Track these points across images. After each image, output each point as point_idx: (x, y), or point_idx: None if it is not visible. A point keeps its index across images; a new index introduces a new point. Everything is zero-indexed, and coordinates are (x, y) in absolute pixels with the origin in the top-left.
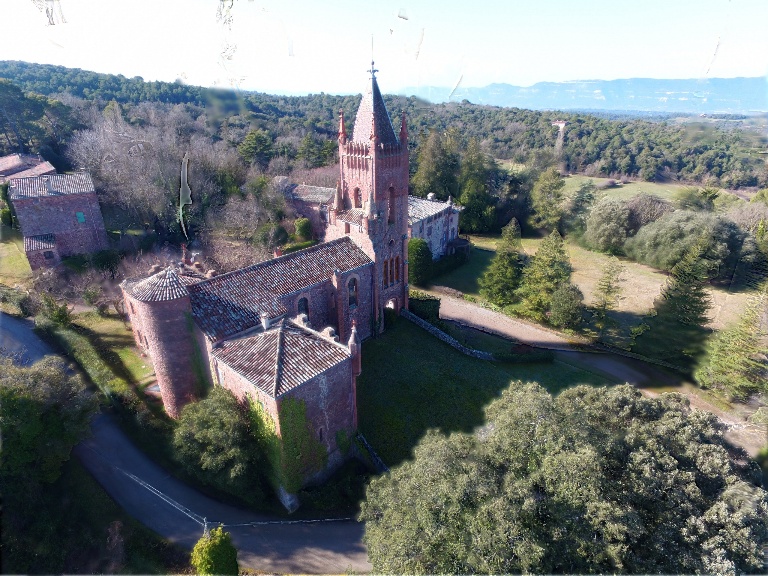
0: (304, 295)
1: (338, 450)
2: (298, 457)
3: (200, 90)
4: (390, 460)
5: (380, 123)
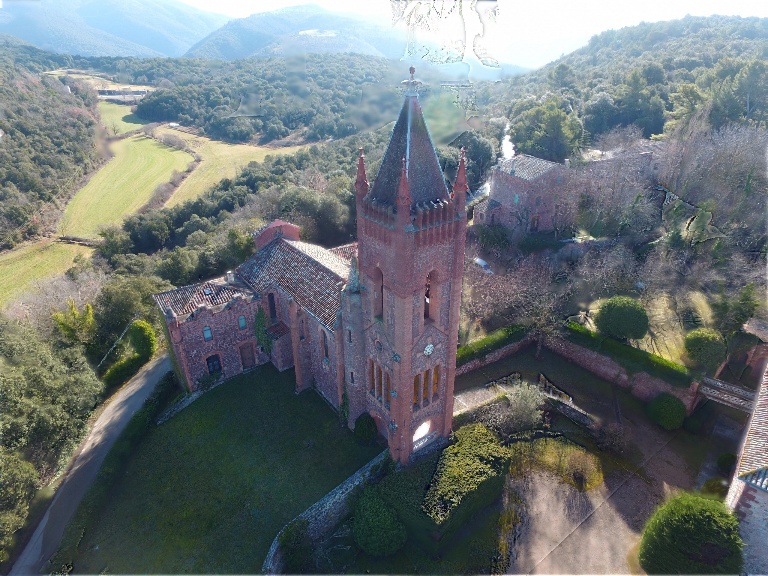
0: None
1: None
2: None
3: (351, 96)
4: (168, 425)
5: (391, 168)
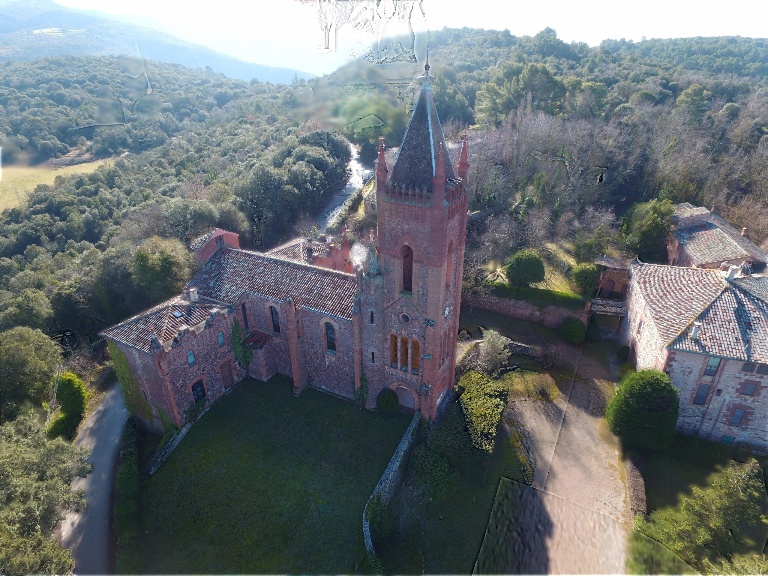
0: (274, 304)
1: None
2: (129, 392)
3: (297, 95)
4: (165, 470)
5: (412, 154)
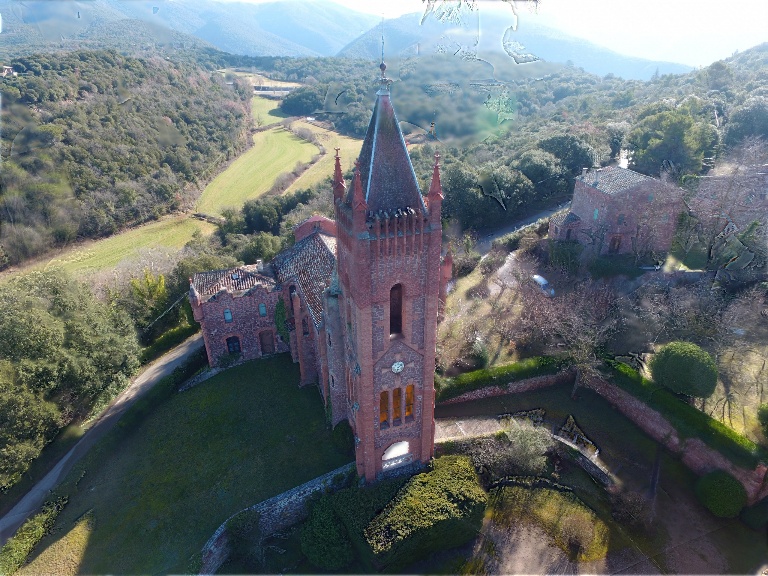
0: None
1: None
2: None
3: None
4: (186, 394)
5: (361, 171)
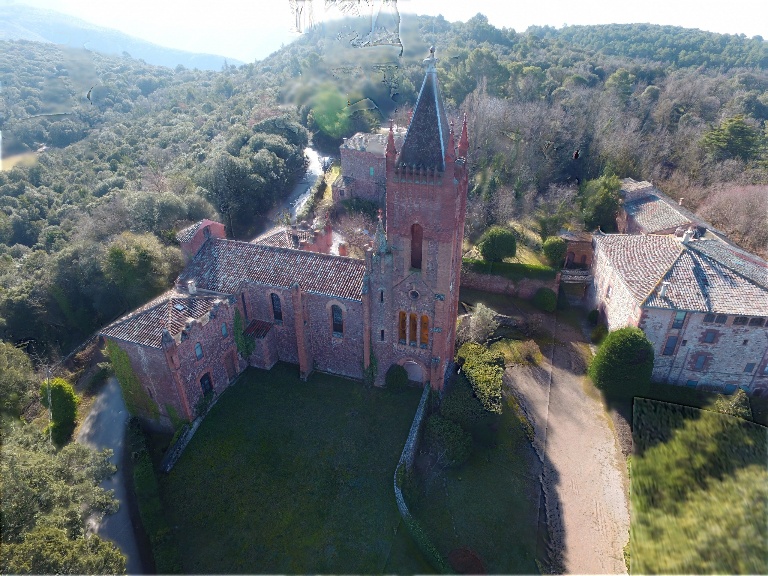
0: (276, 292)
1: (170, 419)
2: (130, 392)
3: (284, 80)
4: (182, 466)
5: (420, 135)
